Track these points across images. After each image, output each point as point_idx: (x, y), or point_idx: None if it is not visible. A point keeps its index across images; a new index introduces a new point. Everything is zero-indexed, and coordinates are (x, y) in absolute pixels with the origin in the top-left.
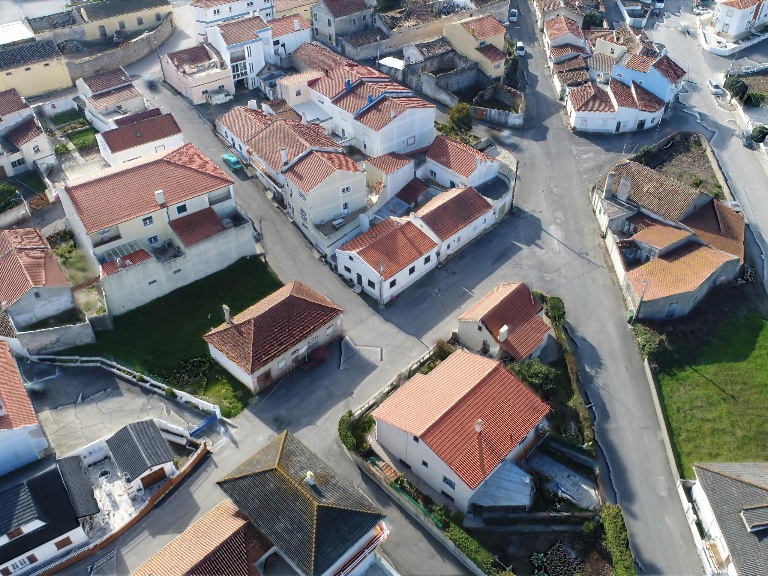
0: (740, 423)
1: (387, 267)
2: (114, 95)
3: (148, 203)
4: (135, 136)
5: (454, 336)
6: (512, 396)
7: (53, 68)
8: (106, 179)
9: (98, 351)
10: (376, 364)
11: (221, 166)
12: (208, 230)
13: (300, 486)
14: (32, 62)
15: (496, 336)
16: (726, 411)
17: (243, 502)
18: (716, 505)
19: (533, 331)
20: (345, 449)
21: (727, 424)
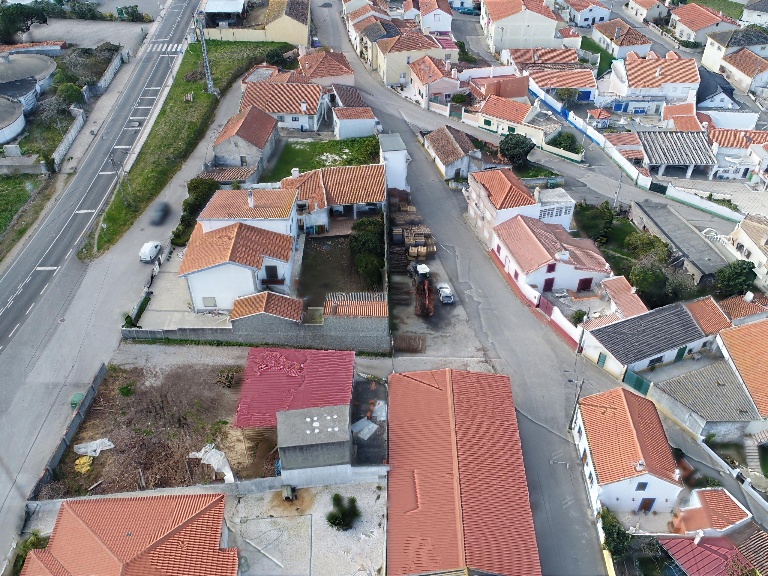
0: (719, 6)
1: (604, 7)
2: (378, 2)
3: (545, 7)
4: (445, 7)
5: (645, 20)
6: (707, 8)
7: (309, 6)
8: (525, 3)
9: (604, 69)
10: (647, 37)
11: (467, 16)
12: (558, 16)
13: (747, 28)
14: (307, 3)
15: (666, 6)
16: (712, 5)
17: (739, 45)
18: (762, 10)
19: (664, 3)
20: (692, 52)
21: (718, 7)
